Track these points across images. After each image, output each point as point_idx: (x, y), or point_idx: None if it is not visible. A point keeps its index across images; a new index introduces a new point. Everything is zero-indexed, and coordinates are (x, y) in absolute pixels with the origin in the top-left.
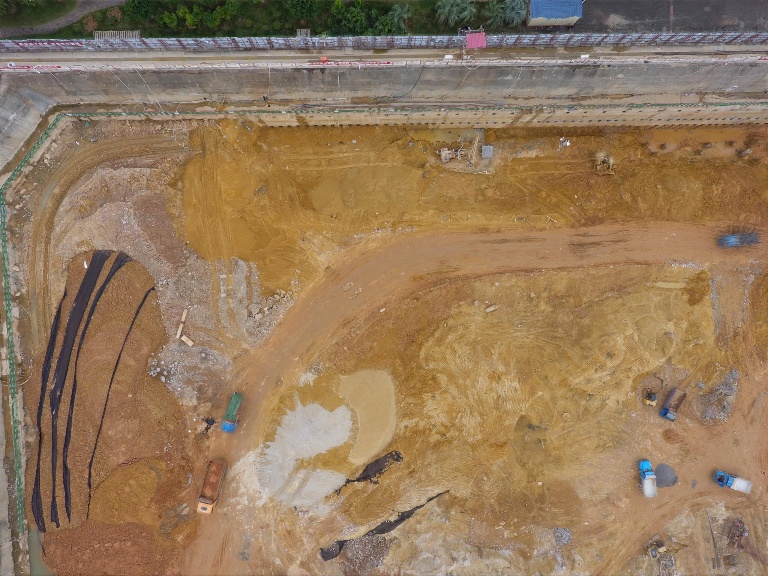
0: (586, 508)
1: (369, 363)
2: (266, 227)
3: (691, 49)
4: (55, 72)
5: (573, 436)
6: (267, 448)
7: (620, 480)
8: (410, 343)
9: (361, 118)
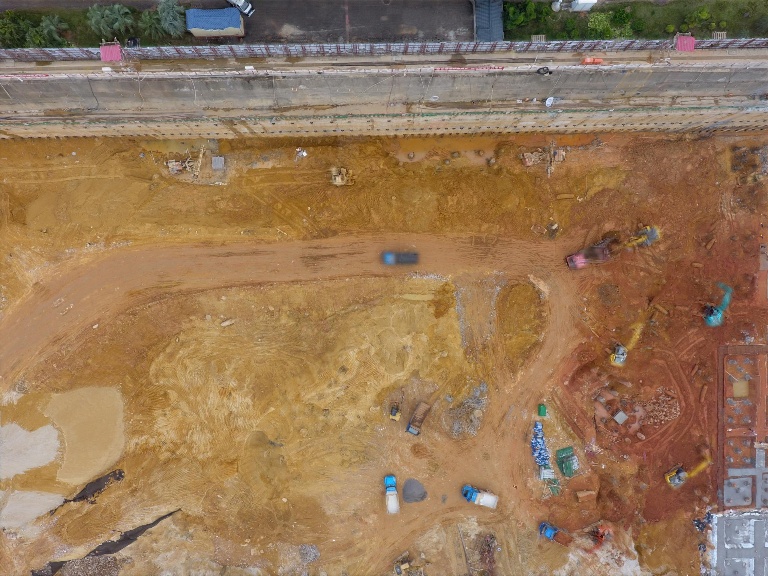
0: (333, 524)
1: (89, 380)
2: None
3: (368, 59)
4: None
5: (311, 452)
6: None
7: (368, 496)
8: (140, 359)
9: (65, 130)
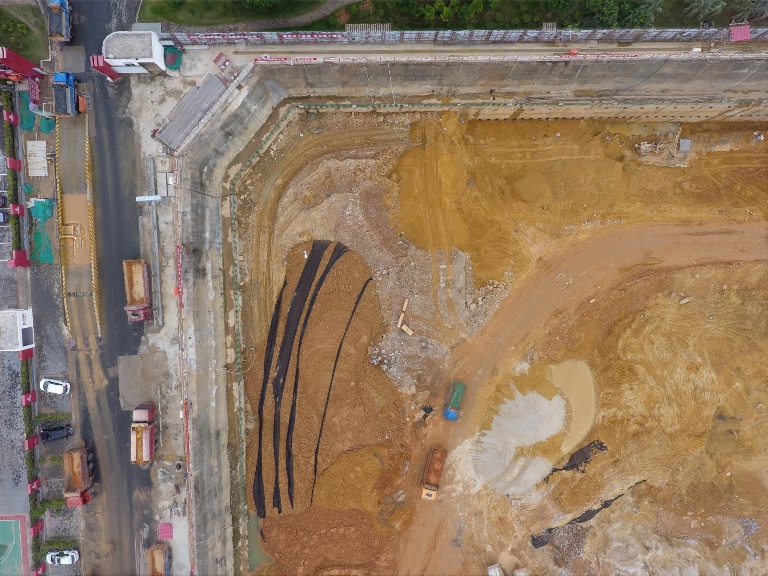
0: None
1: (573, 353)
2: (481, 218)
3: None
4: (307, 64)
5: (766, 427)
6: (483, 436)
7: None
8: (608, 334)
9: (576, 111)
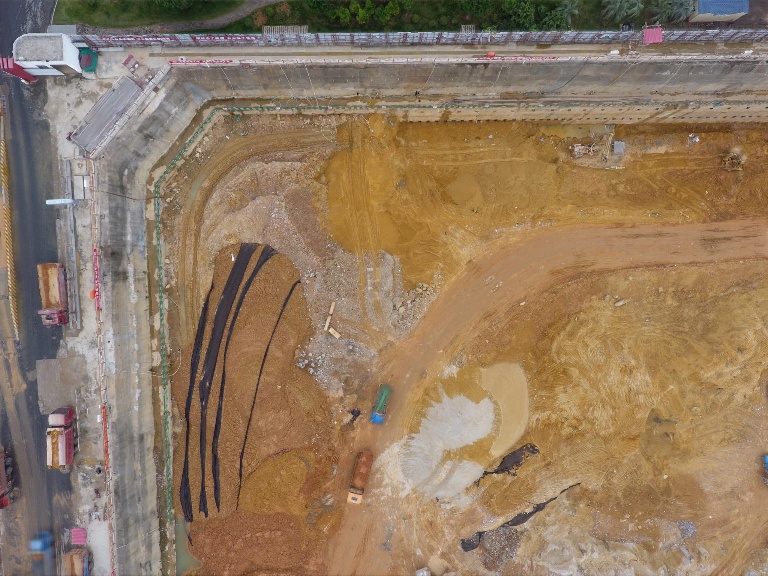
0: (710, 501)
1: (505, 356)
2: (410, 221)
3: None
4: (224, 66)
5: (701, 430)
6: (411, 440)
7: (744, 474)
8: (542, 337)
9: (505, 113)
